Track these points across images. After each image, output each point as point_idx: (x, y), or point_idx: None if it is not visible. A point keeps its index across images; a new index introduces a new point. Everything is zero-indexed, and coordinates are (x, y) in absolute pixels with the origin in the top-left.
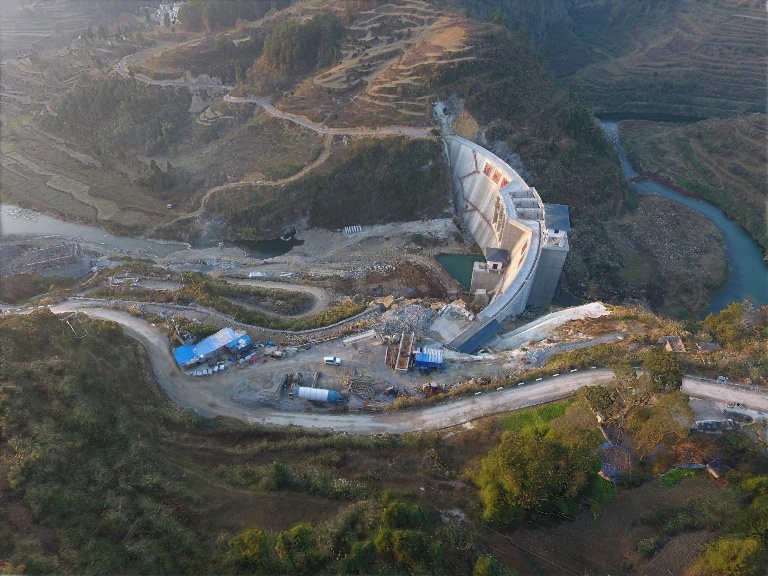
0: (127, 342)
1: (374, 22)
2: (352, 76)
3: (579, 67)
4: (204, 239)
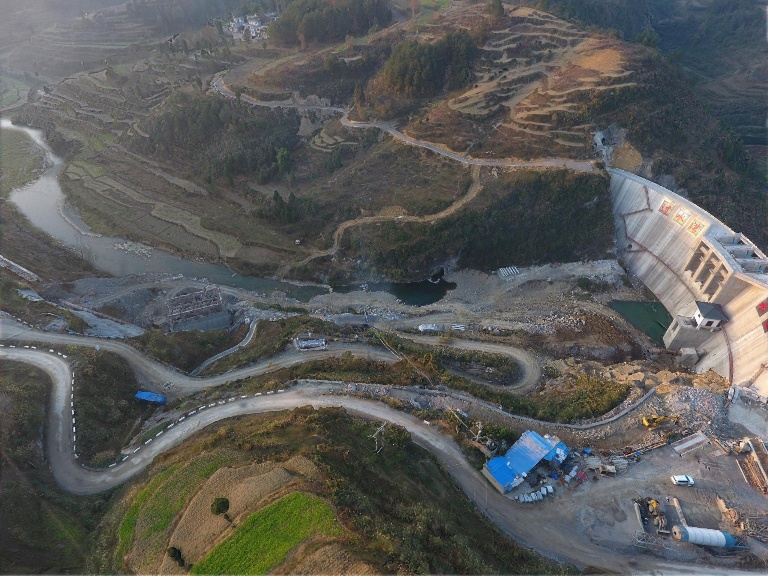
0: (421, 452)
1: (509, 42)
2: (491, 101)
3: None
4: (346, 281)
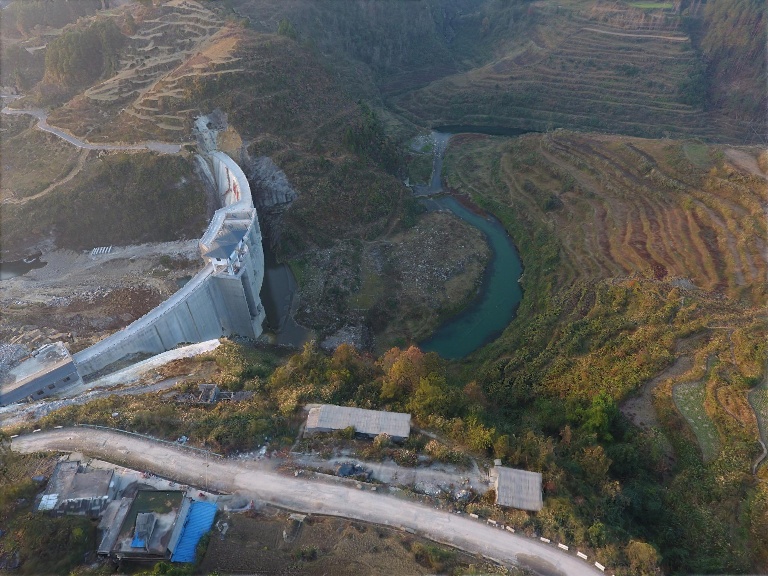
0: None
1: (158, 31)
2: (126, 87)
3: (439, 78)
4: None
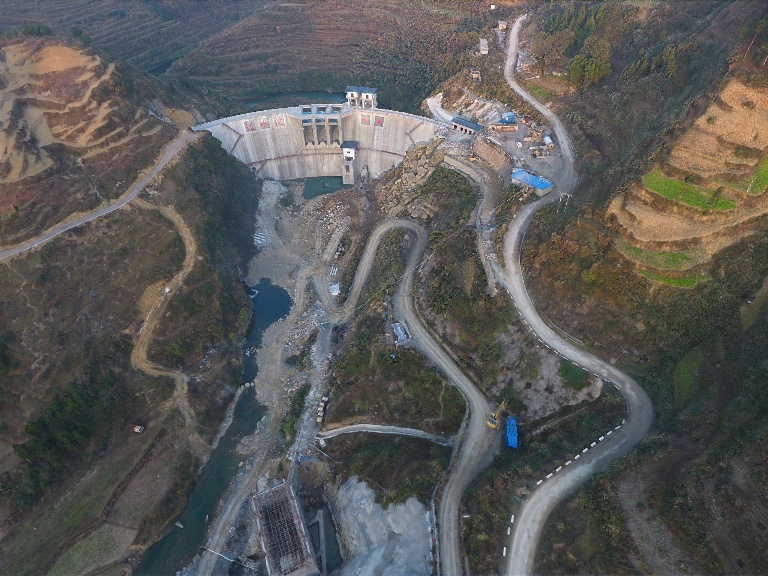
0: None
1: None
2: None
3: None
4: (238, 368)
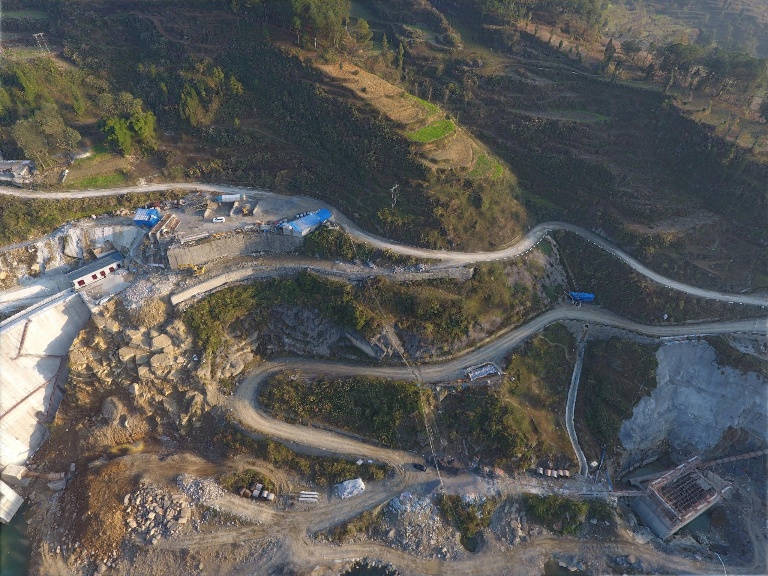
0: (370, 219)
1: None
2: None
3: None
4: None
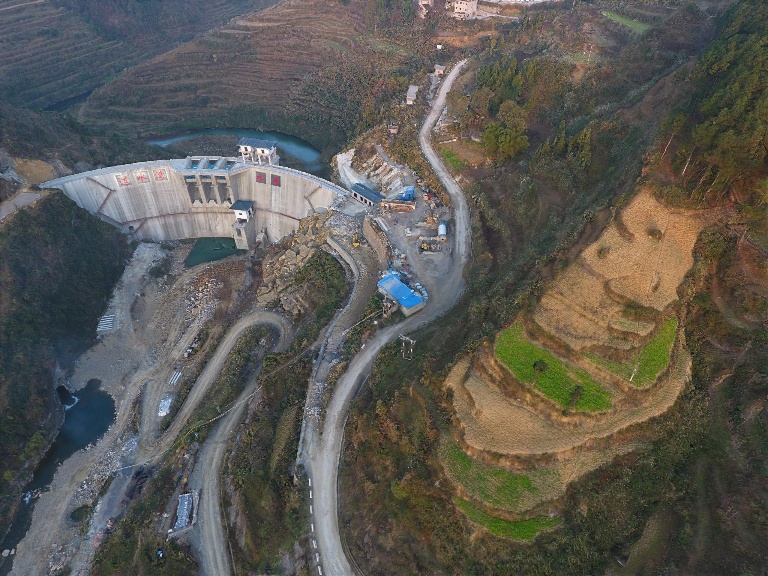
0: None
1: None
2: None
3: None
4: (2, 525)
